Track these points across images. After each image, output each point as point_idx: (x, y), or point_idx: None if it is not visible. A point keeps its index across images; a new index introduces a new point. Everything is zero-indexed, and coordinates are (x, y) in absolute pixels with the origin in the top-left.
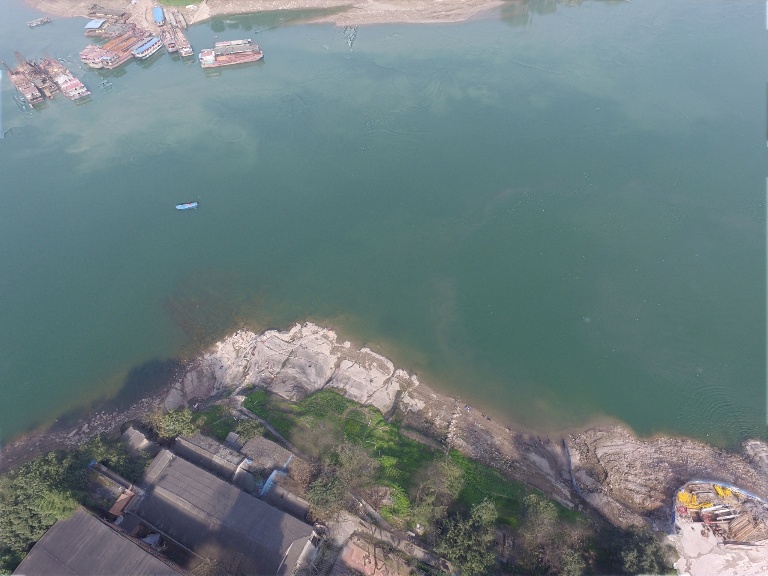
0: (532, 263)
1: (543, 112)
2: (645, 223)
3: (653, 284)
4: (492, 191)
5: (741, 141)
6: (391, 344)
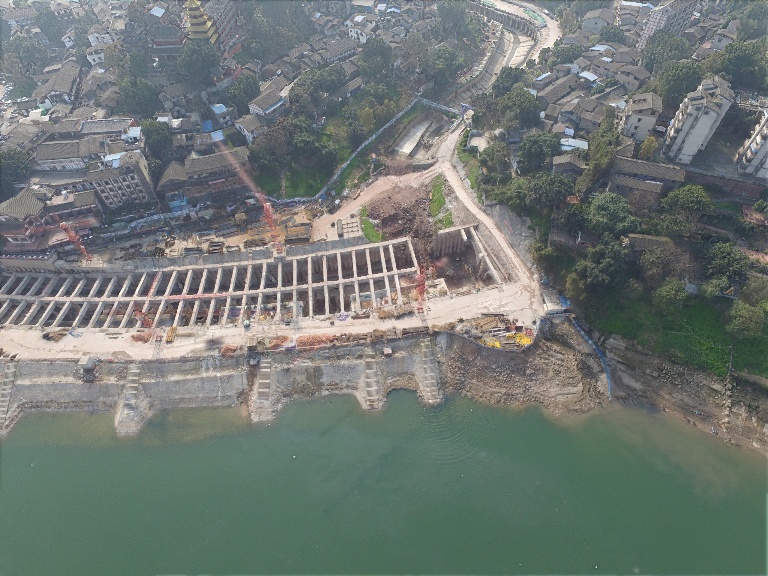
0: None
1: None
2: None
3: None
4: None
5: None
6: None
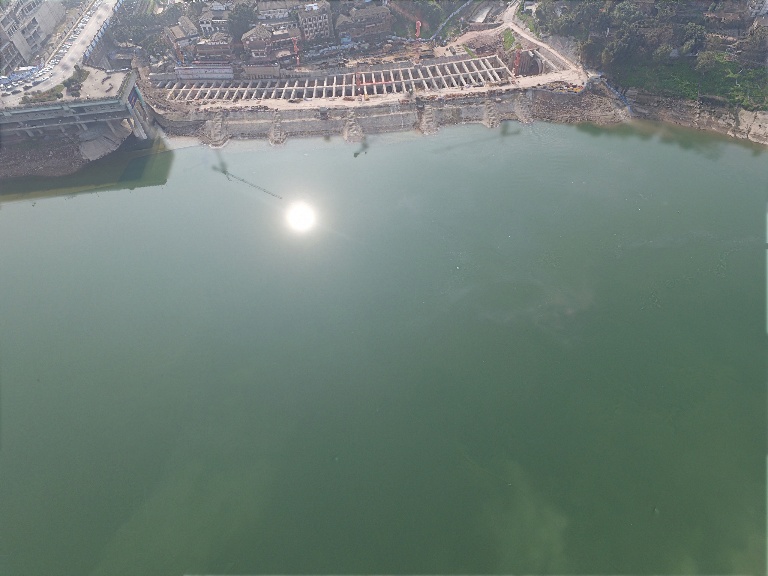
0: (684, 204)
1: (766, 504)
2: (581, 247)
3: (577, 194)
4: (765, 276)
5: (424, 396)
6: (762, 151)
